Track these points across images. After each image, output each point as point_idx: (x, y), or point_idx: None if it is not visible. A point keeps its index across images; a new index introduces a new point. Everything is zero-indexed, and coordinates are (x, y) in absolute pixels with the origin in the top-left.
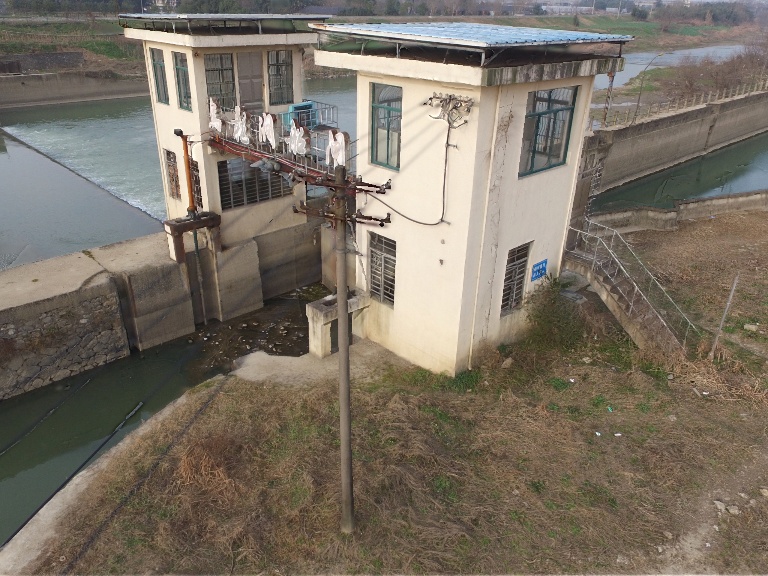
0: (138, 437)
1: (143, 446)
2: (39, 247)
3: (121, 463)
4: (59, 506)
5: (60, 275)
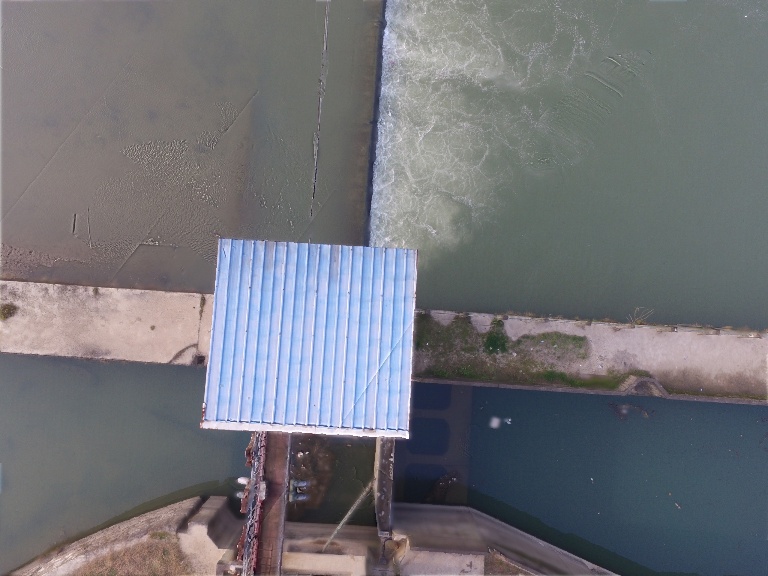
0: (111, 553)
1: (107, 564)
2: (260, 106)
3: (95, 567)
4: (65, 571)
5: (169, 331)
